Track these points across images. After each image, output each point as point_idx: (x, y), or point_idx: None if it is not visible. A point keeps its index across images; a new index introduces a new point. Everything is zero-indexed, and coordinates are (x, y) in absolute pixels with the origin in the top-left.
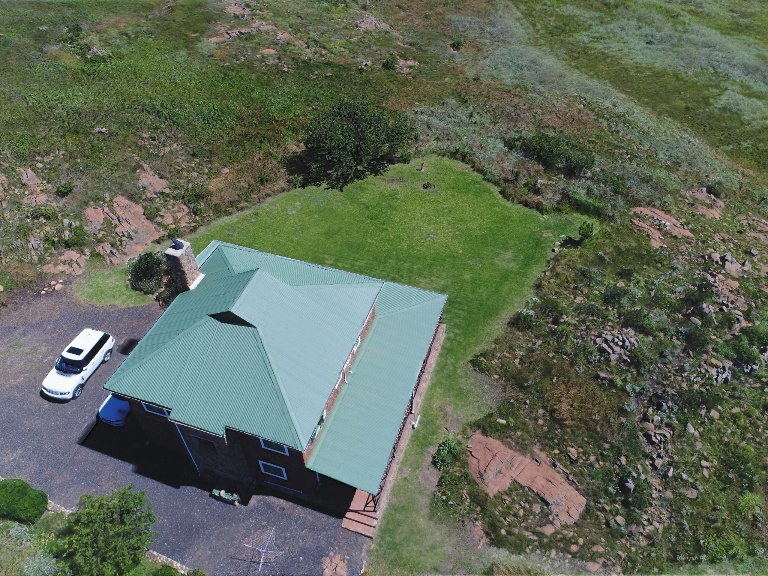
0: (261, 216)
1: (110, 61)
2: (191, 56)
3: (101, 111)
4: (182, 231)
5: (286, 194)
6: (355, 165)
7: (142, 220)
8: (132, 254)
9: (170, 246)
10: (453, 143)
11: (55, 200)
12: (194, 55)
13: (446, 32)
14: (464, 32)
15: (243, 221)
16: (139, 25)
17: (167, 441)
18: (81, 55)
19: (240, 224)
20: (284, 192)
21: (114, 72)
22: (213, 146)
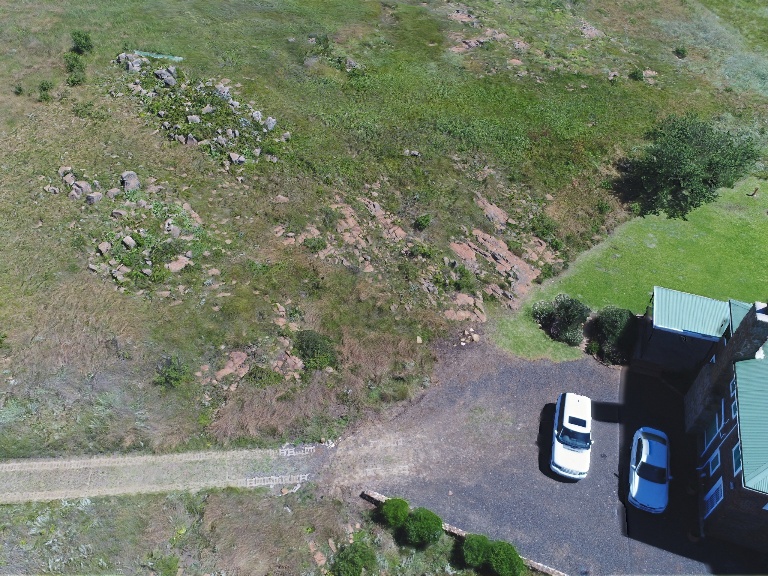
0: (623, 250)
1: (367, 74)
2: (442, 68)
3: (396, 131)
4: (556, 269)
5: (630, 224)
6: (679, 190)
7: (514, 257)
8: (521, 296)
9: (757, 311)
10: (767, 164)
11: (416, 234)
12: (445, 67)
13: (661, 38)
14: (678, 38)
15: (608, 256)
16: (375, 35)
17: (744, 537)
18: (341, 68)
19: (607, 260)
20: (626, 222)
21: (381, 87)
22: (522, 169)
